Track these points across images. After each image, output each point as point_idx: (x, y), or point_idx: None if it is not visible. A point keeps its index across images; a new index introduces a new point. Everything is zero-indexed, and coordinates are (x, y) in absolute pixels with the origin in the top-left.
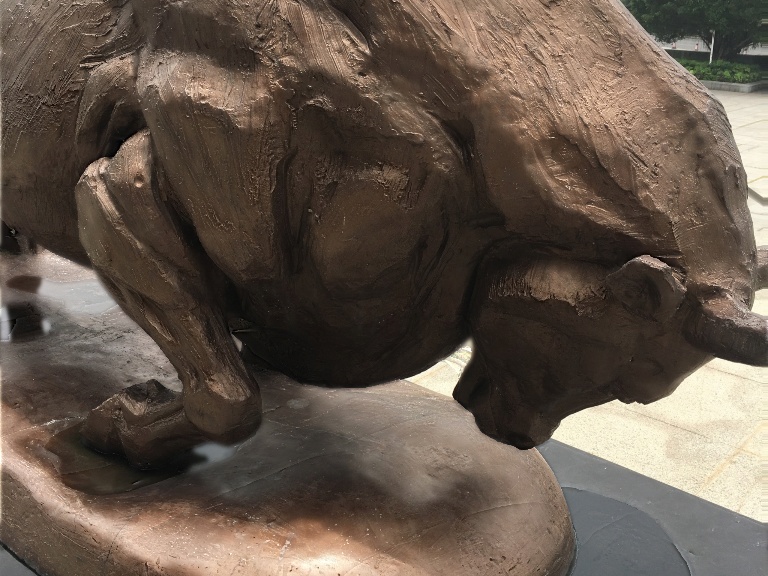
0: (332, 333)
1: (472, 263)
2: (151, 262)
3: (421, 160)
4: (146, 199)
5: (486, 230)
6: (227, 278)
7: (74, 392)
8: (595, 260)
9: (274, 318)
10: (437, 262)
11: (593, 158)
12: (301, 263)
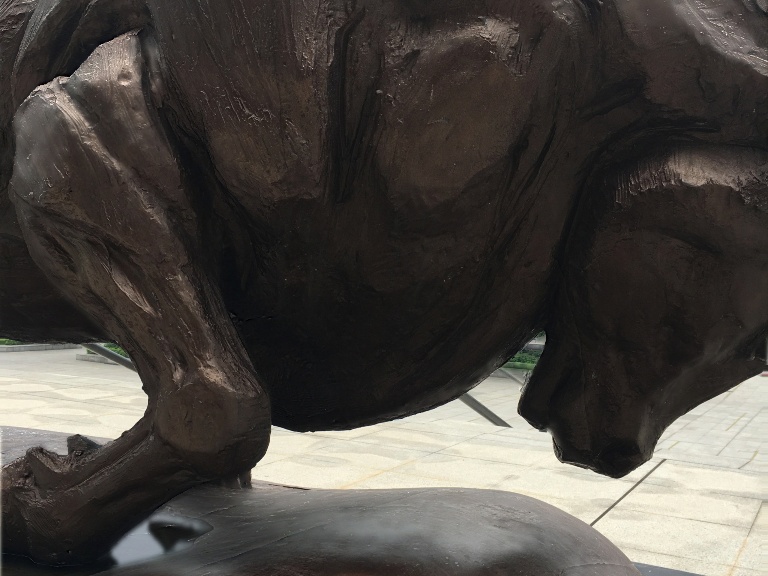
0: (368, 314)
1: (580, 174)
2: (132, 191)
3: (536, 10)
4: (134, 101)
5: (607, 116)
6: (225, 239)
7: None
8: (749, 143)
9: (290, 292)
10: (535, 174)
11: (749, 1)
12: (350, 185)
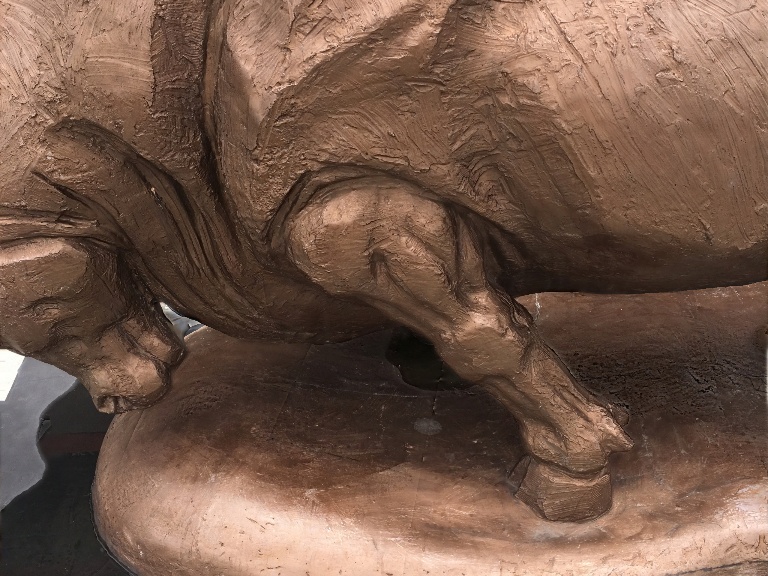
0: None
1: None
2: None
3: None
4: None
5: None
6: None
7: (578, 322)
8: None
9: None
10: None
11: None
12: None
